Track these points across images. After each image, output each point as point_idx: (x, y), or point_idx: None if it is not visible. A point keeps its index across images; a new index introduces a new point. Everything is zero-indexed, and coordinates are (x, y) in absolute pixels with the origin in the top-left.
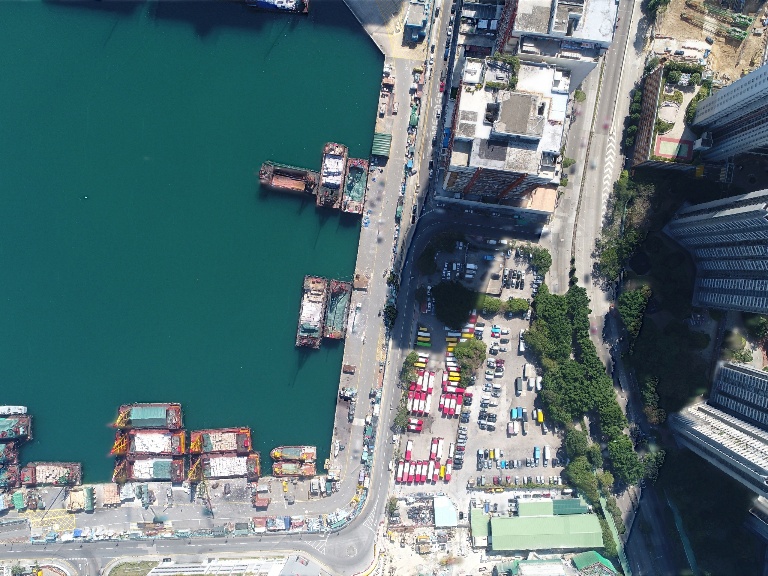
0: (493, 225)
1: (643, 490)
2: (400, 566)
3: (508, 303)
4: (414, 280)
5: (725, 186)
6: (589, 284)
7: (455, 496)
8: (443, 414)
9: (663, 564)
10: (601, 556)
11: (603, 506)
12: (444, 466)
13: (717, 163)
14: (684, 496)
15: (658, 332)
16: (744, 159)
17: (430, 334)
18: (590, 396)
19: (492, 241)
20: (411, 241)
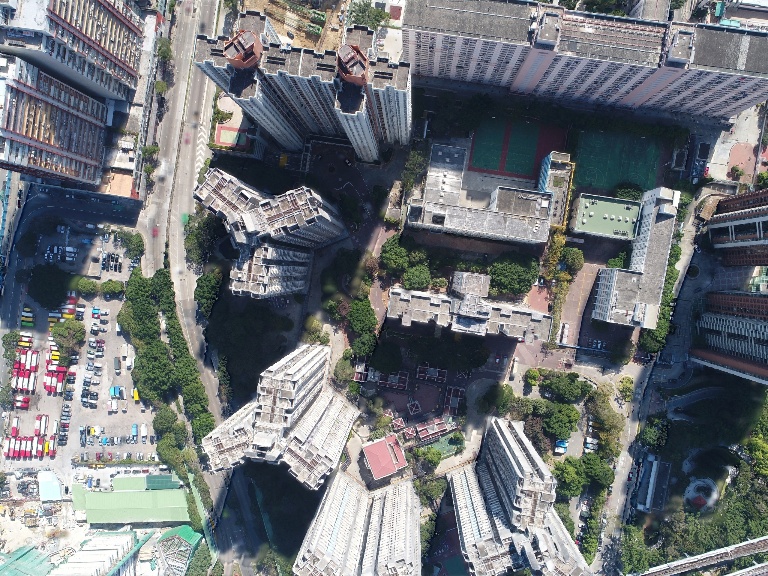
0: (94, 210)
1: (235, 467)
2: (10, 539)
3: (101, 285)
4: (21, 262)
5: (303, 175)
6: (183, 268)
7: (61, 471)
8: (49, 392)
9: (254, 538)
10: (192, 530)
11: (191, 481)
12: (48, 442)
13: (296, 152)
14: (244, 471)
15: (234, 314)
16: (324, 149)
17: (34, 314)
18: (167, 375)
19: (90, 225)
20: (18, 225)
